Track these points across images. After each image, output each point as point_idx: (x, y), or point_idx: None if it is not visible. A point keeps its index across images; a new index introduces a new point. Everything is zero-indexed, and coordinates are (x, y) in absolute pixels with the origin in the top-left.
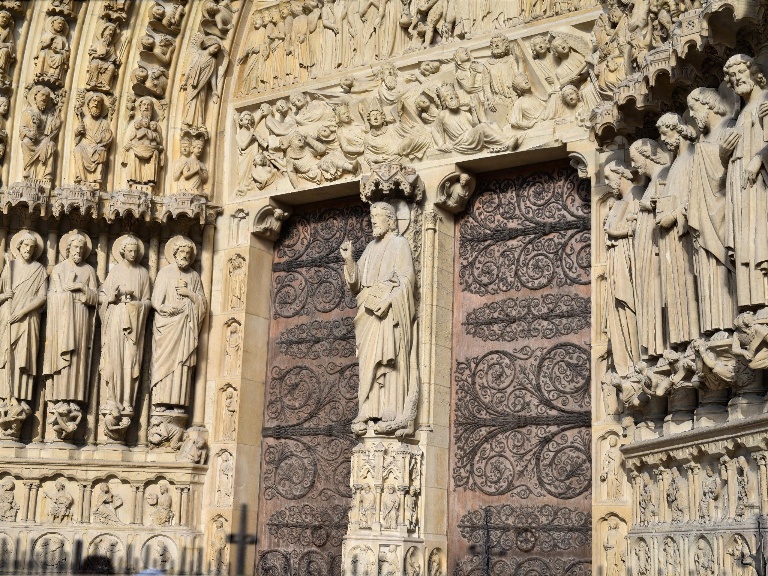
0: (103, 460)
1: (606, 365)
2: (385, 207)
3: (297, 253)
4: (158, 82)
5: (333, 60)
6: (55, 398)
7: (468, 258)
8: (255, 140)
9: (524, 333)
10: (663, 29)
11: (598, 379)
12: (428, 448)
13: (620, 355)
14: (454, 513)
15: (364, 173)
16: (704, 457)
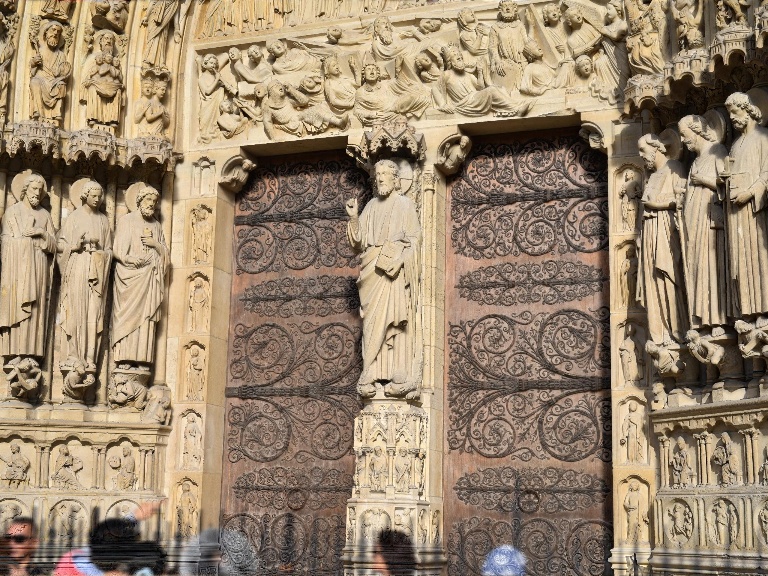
0: (63, 420)
1: (624, 332)
2: (392, 165)
3: (263, 207)
4: (120, 15)
5: (314, 8)
6: (13, 353)
7: (461, 221)
8: (220, 85)
9: (524, 298)
10: (728, 10)
11: (617, 346)
12: (431, 411)
13: (656, 323)
14: (449, 475)
15: (353, 128)
16: (766, 423)
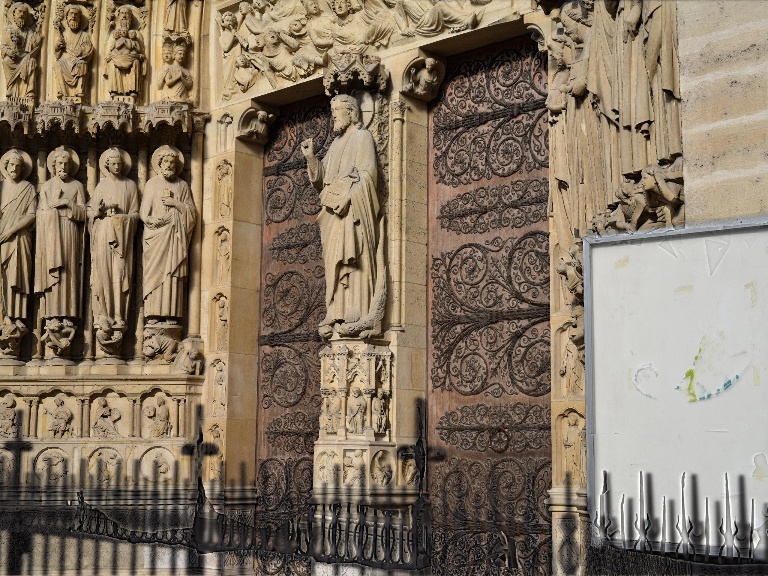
0: (99, 375)
1: None
2: (345, 99)
3: (285, 155)
4: None
5: None
6: (48, 315)
7: (441, 148)
8: (238, 41)
9: (495, 223)
10: None
11: None
12: (399, 349)
13: (565, 240)
14: (433, 415)
15: None
16: None
